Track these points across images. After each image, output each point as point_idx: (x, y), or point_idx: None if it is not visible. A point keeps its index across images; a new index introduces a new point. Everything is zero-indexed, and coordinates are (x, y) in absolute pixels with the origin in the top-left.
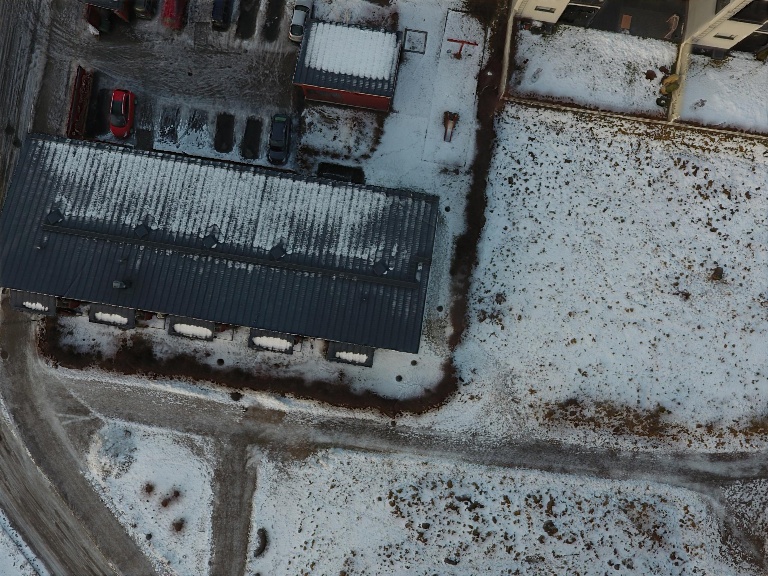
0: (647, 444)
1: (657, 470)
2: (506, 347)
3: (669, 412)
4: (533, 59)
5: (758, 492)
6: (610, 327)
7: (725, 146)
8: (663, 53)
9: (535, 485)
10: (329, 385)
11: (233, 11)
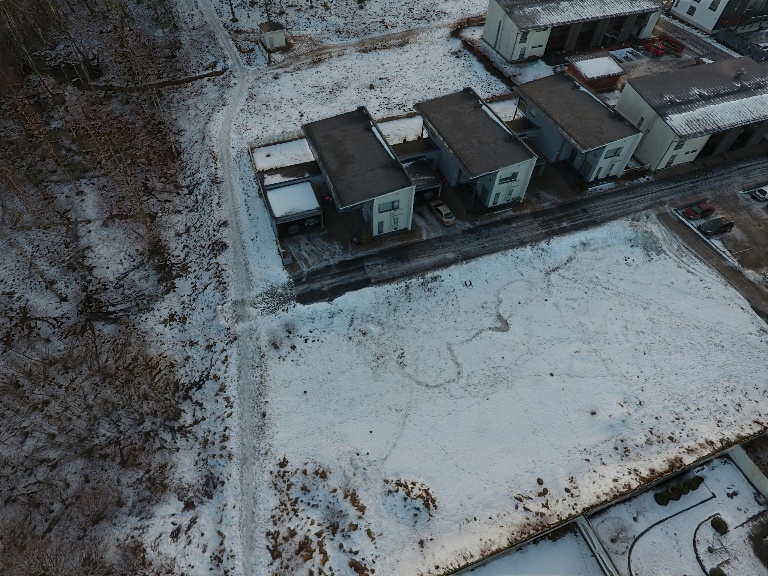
0: None
1: None
2: None
3: None
4: None
5: None
6: None
7: None
8: None
9: None
10: None
11: None
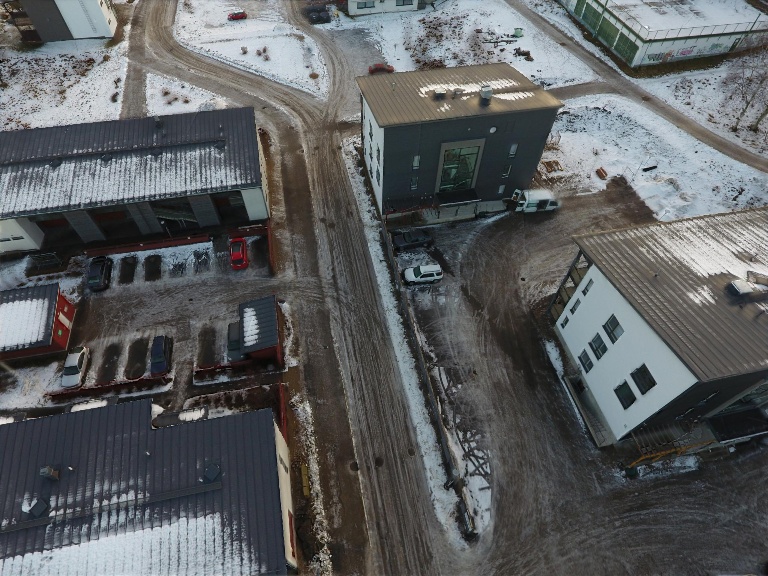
0: None
1: None
2: None
3: None
4: None
5: None
6: None
7: None
8: None
9: None
10: None
11: None
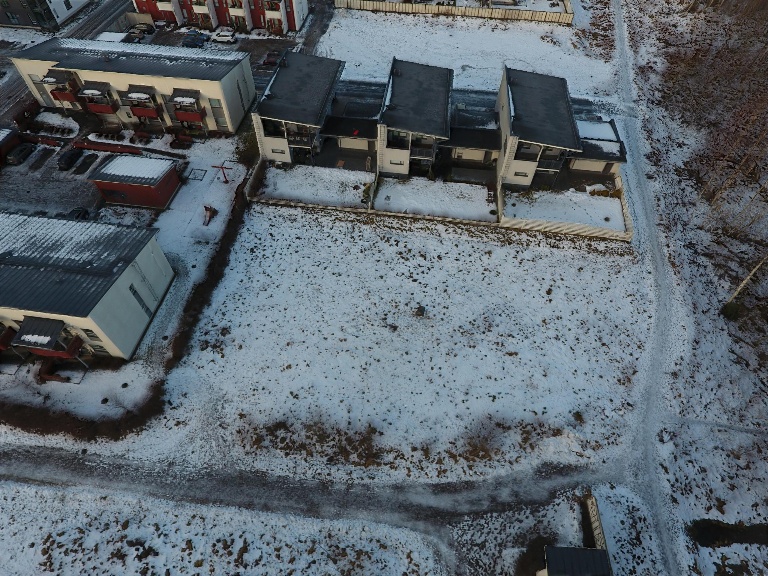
0: (363, 475)
1: (374, 506)
2: (223, 373)
3: (381, 433)
4: None
5: (491, 530)
6: (324, 354)
7: (416, 227)
8: (365, 177)
9: (229, 526)
10: (29, 409)
11: (77, 162)
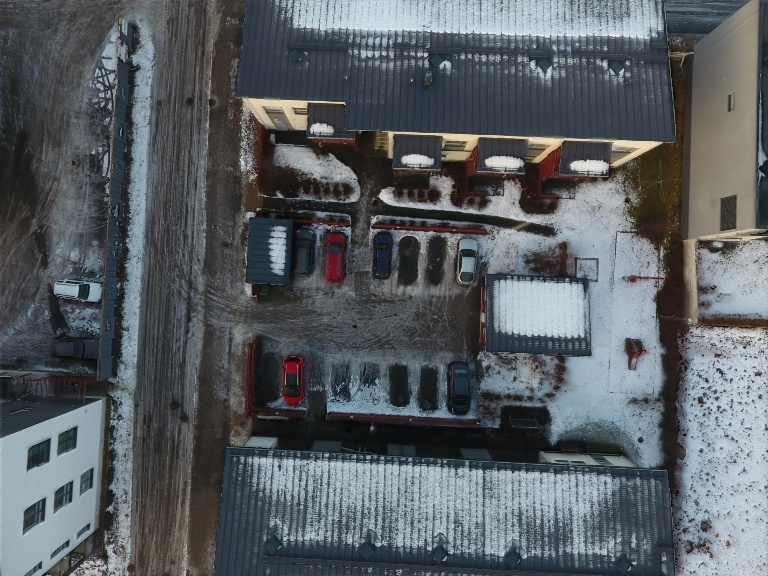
0: None
1: None
2: (717, 575)
3: None
4: (715, 278)
5: None
6: None
7: None
8: None
9: None
10: None
11: (392, 257)
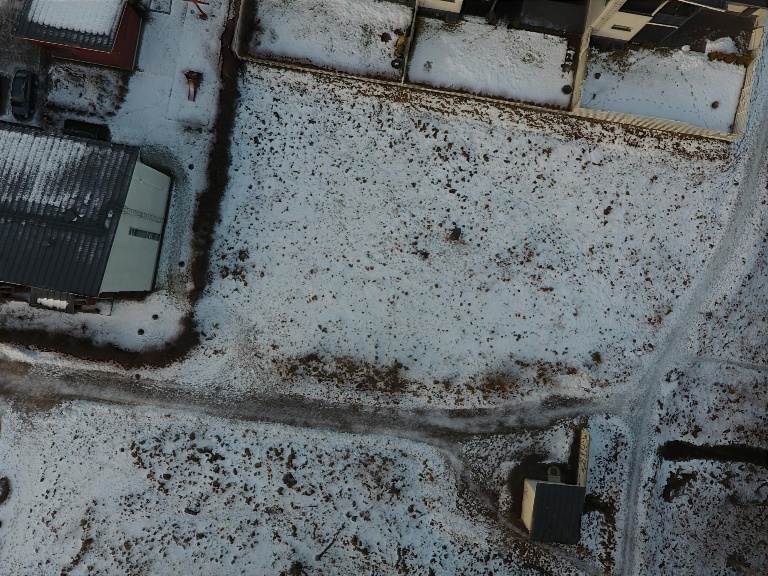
0: (389, 400)
1: (398, 425)
2: (249, 303)
3: (406, 368)
4: (272, 20)
5: (494, 447)
6: (350, 285)
7: (461, 109)
8: (398, 16)
9: (277, 438)
10: (72, 338)
11: None
